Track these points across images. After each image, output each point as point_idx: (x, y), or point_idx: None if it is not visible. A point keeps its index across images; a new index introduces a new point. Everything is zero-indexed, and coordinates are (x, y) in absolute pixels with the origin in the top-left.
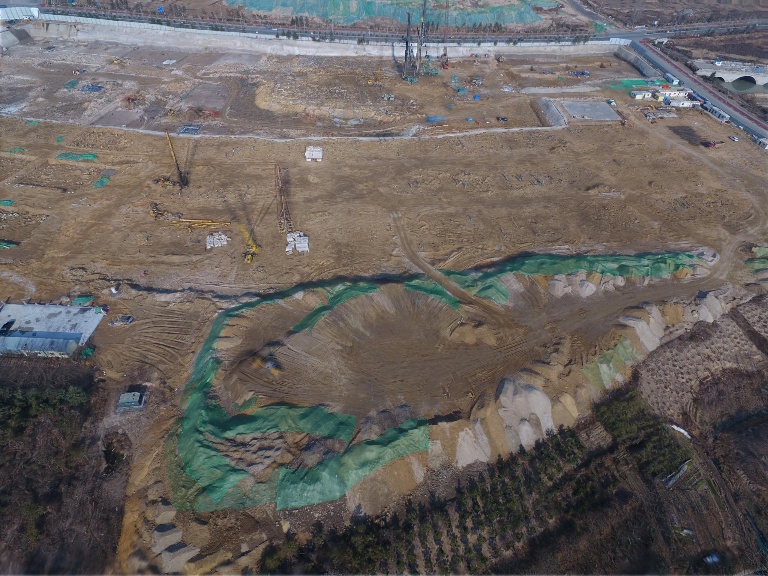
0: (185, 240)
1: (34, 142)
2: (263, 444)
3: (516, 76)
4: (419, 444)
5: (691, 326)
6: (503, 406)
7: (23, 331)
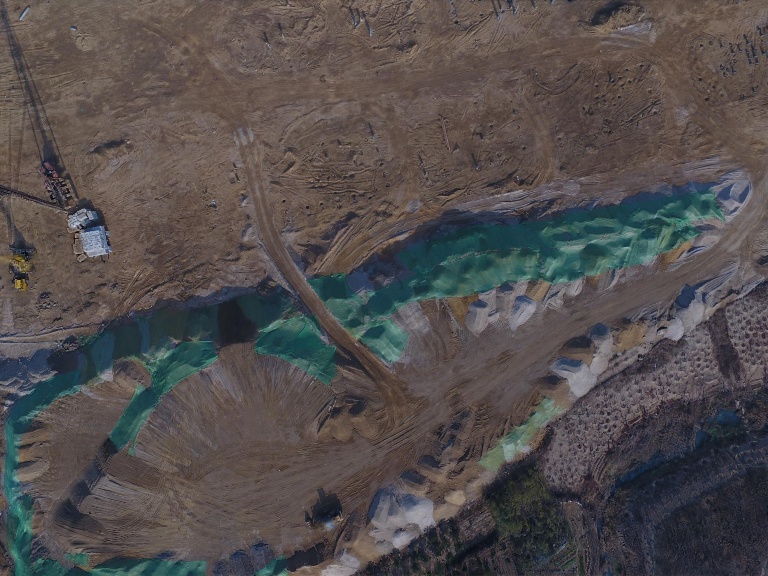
0: None
1: None
2: None
3: None
4: None
5: (648, 350)
6: (375, 527)
7: None
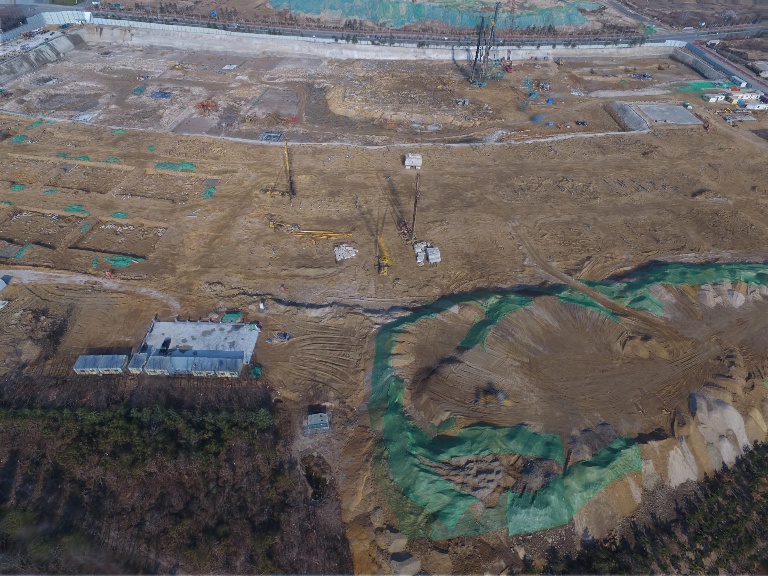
0: (312, 252)
1: (127, 151)
2: (480, 467)
3: (580, 79)
4: (633, 464)
5: None
6: (701, 422)
7: (182, 350)
